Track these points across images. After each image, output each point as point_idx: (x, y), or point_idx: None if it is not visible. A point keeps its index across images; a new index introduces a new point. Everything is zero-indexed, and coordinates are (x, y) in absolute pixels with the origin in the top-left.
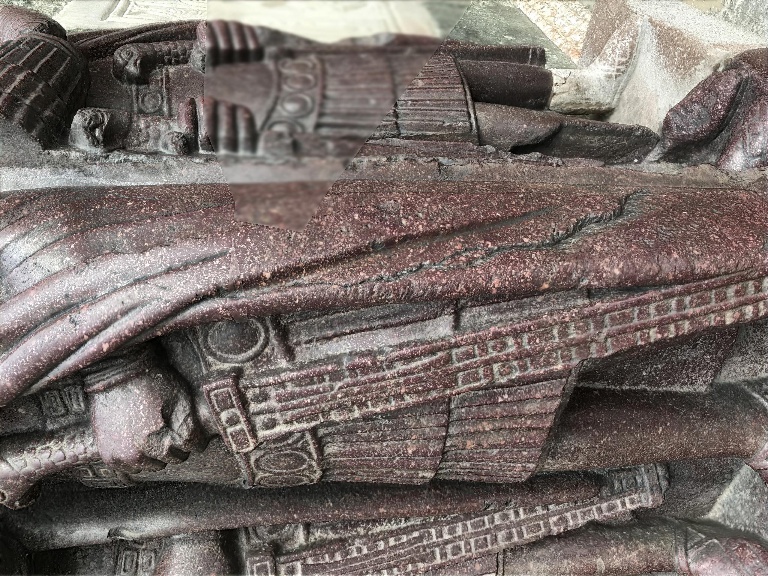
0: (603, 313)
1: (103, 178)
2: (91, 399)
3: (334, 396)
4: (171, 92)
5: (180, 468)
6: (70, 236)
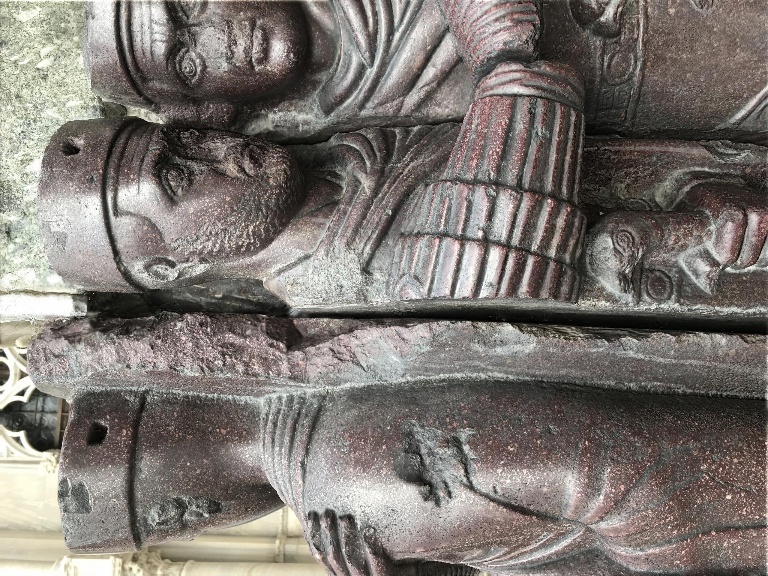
0: None
1: (643, 354)
2: None
3: None
4: (648, 48)
5: None
6: (681, 543)
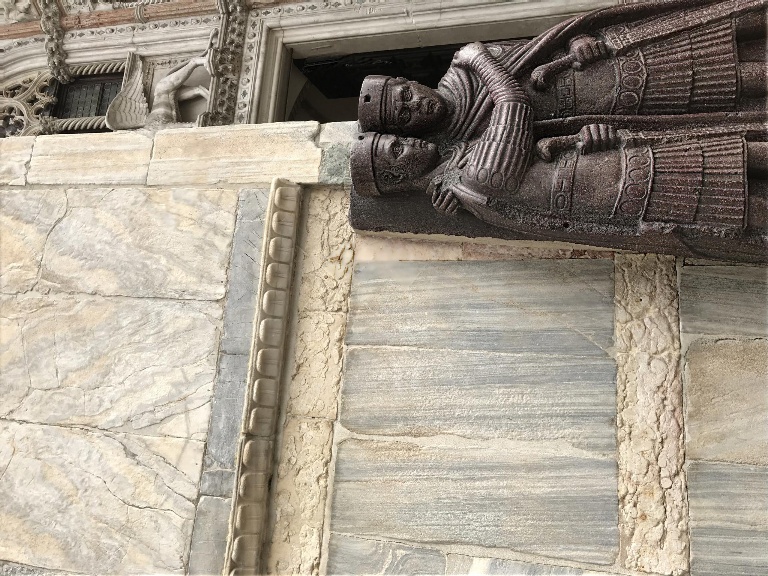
0: (734, 1)
1: None
2: (571, 45)
3: (648, 32)
4: None
5: (594, 78)
6: None
